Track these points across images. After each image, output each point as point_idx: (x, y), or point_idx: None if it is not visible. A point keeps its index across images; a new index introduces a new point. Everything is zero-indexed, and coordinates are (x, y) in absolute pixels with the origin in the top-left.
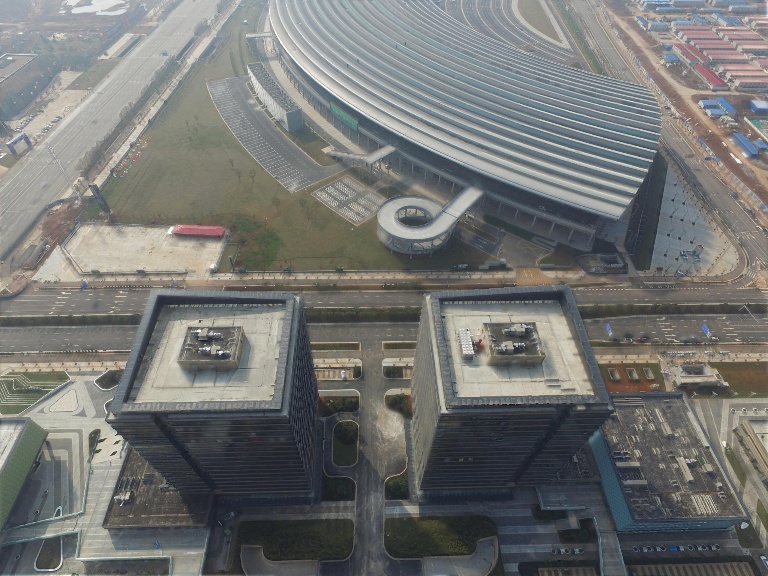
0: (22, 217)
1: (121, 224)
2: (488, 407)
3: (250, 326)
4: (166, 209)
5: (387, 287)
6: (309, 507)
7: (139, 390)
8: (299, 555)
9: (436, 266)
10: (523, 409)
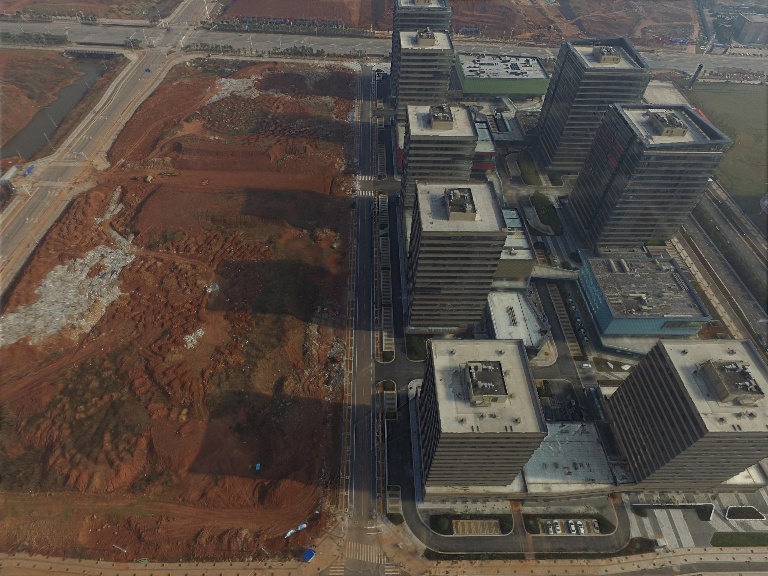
0: (661, 66)
1: (683, 94)
2: (620, 116)
3: (624, 64)
4: (711, 106)
5: (716, 201)
6: (543, 171)
7: (577, 47)
8: (522, 162)
9: (763, 229)
10: (626, 126)
